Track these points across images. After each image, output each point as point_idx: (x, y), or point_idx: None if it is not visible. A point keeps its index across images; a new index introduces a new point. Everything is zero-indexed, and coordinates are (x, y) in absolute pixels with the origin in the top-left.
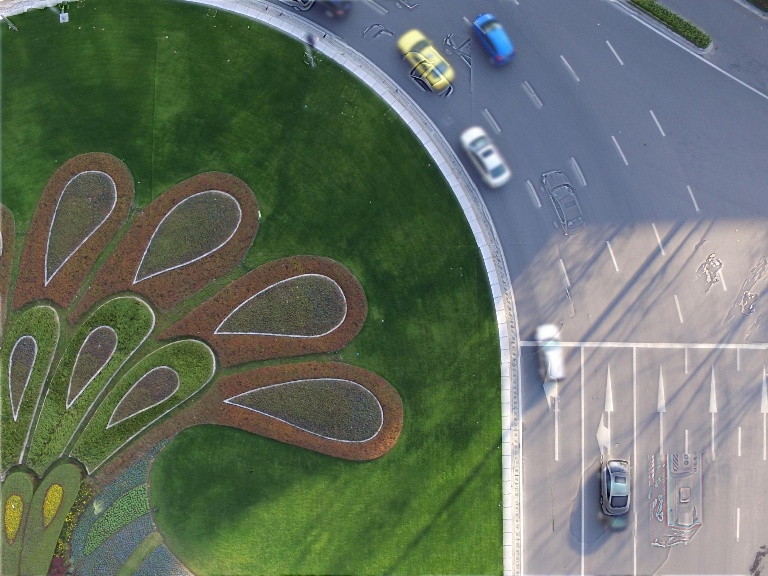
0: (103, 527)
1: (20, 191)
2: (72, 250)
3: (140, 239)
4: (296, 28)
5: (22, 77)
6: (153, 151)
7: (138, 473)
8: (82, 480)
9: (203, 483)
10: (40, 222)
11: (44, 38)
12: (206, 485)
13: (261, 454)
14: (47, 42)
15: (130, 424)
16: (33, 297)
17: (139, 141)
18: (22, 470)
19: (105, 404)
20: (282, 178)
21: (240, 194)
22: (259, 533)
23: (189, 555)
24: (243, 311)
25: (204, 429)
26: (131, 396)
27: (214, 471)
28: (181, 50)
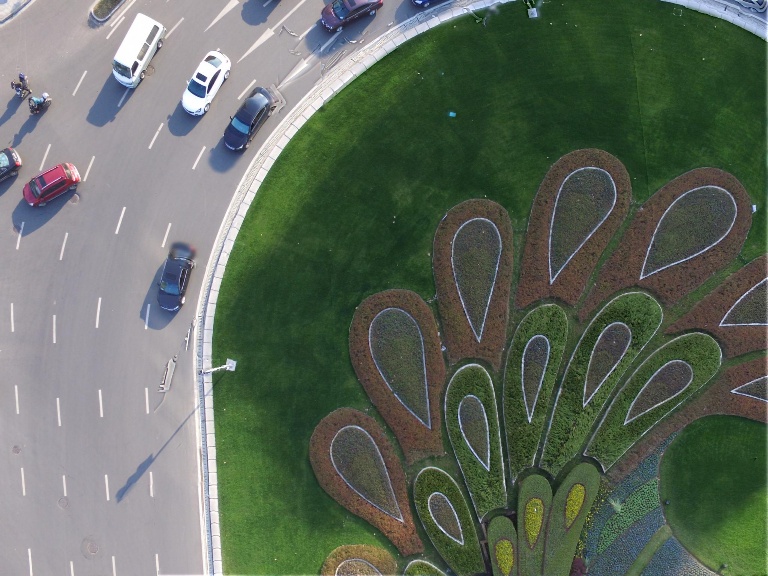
0: (618, 524)
1: (513, 188)
2: (577, 247)
3: (645, 235)
4: (758, 29)
5: (500, 72)
6: (645, 147)
7: (651, 467)
8: (601, 478)
9: (711, 473)
10: (543, 219)
11: (515, 33)
12: (714, 475)
13: (763, 441)
14: (519, 37)
15: (647, 419)
16: (540, 296)
17: (630, 137)
18: (532, 473)
19: (621, 400)
20: (767, 173)
21: (736, 189)
22: (762, 518)
23: (698, 545)
24: (746, 303)
25: (711, 420)
26: (648, 391)
27: (721, 460)
28: (654, 48)
